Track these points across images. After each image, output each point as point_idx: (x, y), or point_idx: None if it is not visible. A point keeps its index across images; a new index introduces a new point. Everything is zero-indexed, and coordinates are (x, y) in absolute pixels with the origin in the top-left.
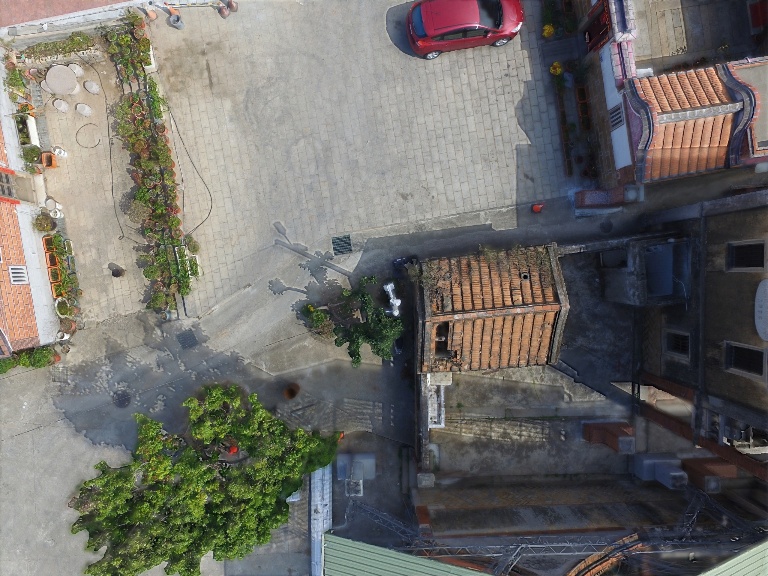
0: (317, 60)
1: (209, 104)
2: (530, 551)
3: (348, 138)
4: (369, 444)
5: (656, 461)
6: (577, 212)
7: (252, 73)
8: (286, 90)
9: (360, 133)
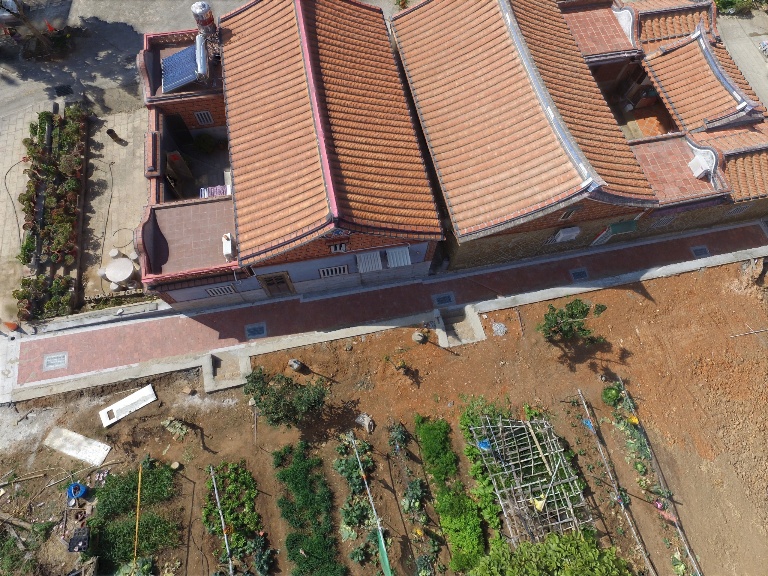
0: None
1: None
2: None
3: None
4: None
5: None
6: None
7: None
8: None
9: None
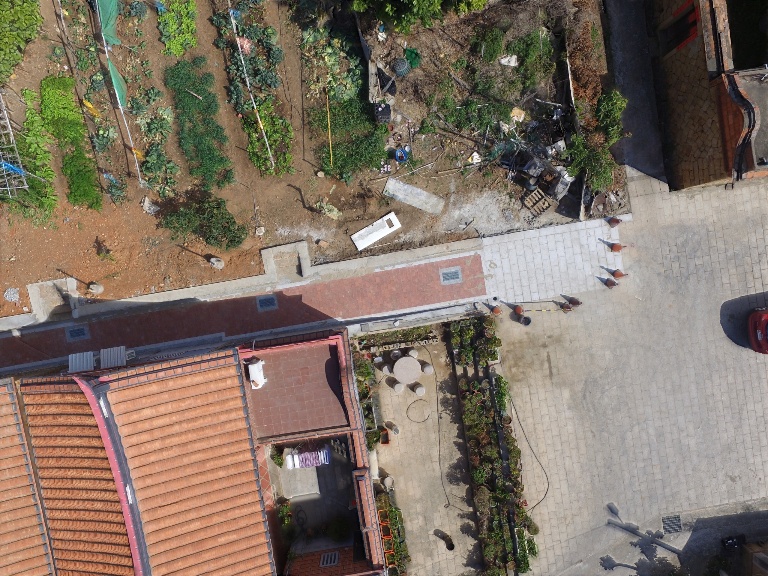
0: (653, 352)
1: (548, 393)
2: None
3: (681, 424)
4: None
5: None
6: None
7: (591, 364)
8: (623, 380)
9: (692, 420)
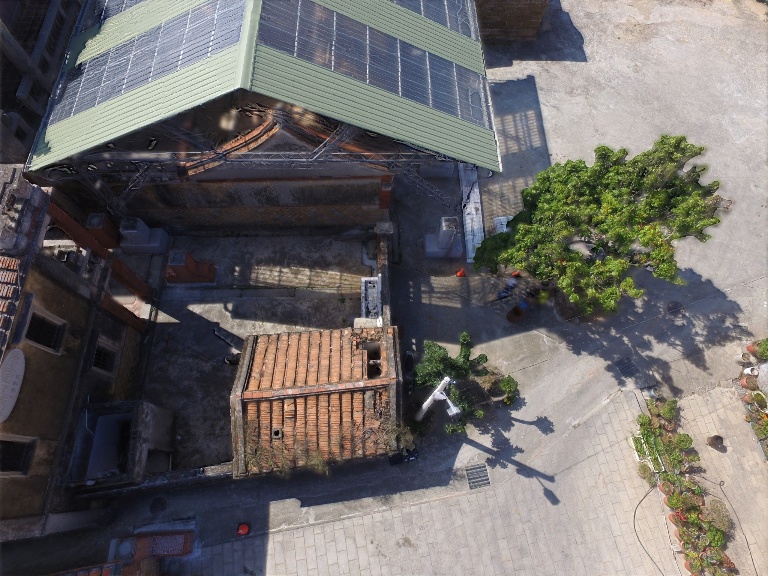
0: None
1: None
2: (304, 156)
3: None
4: (431, 266)
5: (146, 245)
6: (193, 525)
7: None
8: None
9: None
